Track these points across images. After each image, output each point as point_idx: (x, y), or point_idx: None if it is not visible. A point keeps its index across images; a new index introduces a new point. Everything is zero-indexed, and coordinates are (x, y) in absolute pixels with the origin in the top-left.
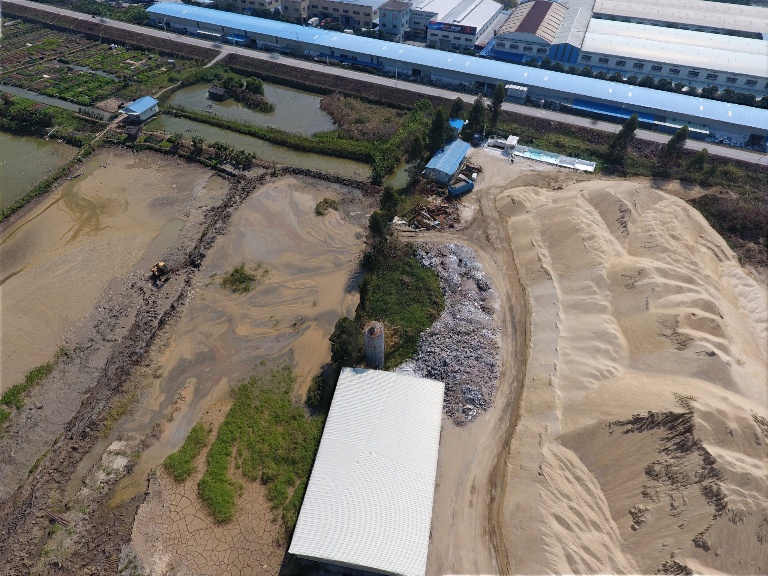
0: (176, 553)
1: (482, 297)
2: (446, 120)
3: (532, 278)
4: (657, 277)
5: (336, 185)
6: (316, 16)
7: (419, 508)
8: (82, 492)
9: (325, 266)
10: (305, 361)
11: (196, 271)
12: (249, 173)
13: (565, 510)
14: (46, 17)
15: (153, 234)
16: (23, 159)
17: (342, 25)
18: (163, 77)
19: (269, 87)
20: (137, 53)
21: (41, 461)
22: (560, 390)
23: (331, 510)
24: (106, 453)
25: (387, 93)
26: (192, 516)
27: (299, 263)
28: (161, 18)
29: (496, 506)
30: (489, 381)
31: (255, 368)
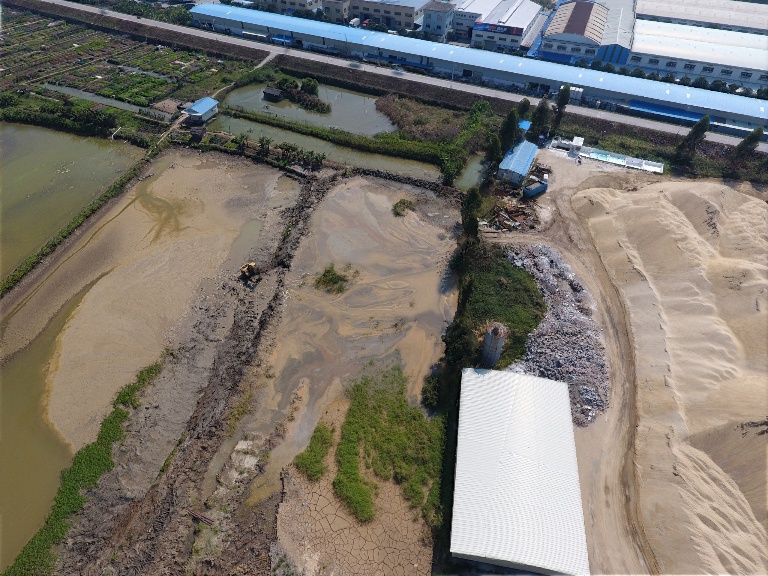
0: (325, 552)
1: (578, 298)
2: (516, 121)
3: (624, 279)
4: (762, 279)
5: (408, 186)
6: (356, 17)
7: (570, 508)
8: (219, 491)
9: (414, 267)
10: (413, 361)
11: (286, 272)
12: (319, 174)
13: (708, 510)
14: (89, 18)
15: (234, 235)
16: (91, 160)
17: (386, 26)
18: (215, 78)
19: (321, 88)
20: (184, 54)
21: (171, 460)
22: (678, 391)
23: (484, 510)
24: (235, 452)
25: (442, 94)
26: (333, 515)
27: (388, 264)
28: (204, 19)
29: (633, 506)
30: (602, 382)
31: (365, 368)
